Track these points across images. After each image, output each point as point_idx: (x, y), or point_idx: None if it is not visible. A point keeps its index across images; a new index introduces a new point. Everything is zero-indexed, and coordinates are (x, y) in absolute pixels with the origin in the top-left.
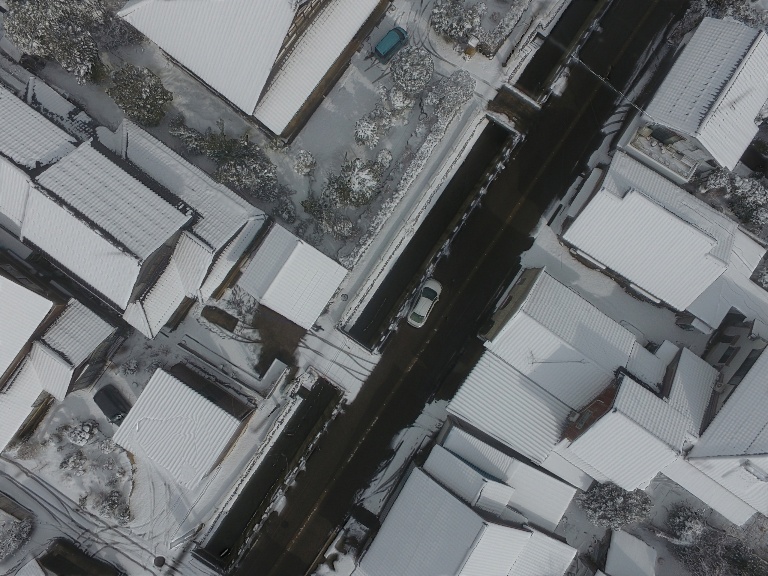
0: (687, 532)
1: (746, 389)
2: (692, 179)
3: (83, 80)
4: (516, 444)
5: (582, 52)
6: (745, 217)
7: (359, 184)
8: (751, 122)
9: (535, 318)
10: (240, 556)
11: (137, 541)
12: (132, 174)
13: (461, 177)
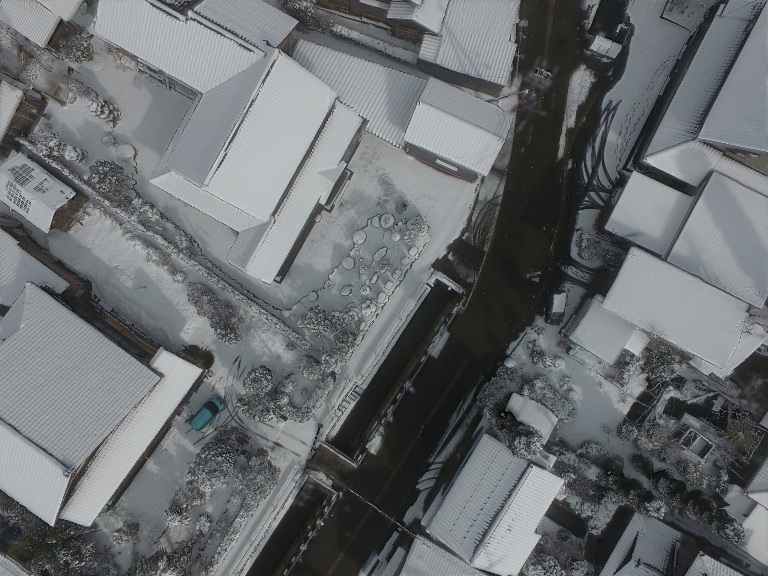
0: None
1: None
2: None
3: None
4: None
5: (396, 411)
6: None
7: None
8: (531, 534)
9: None
10: None
11: None
12: None
13: (287, 521)
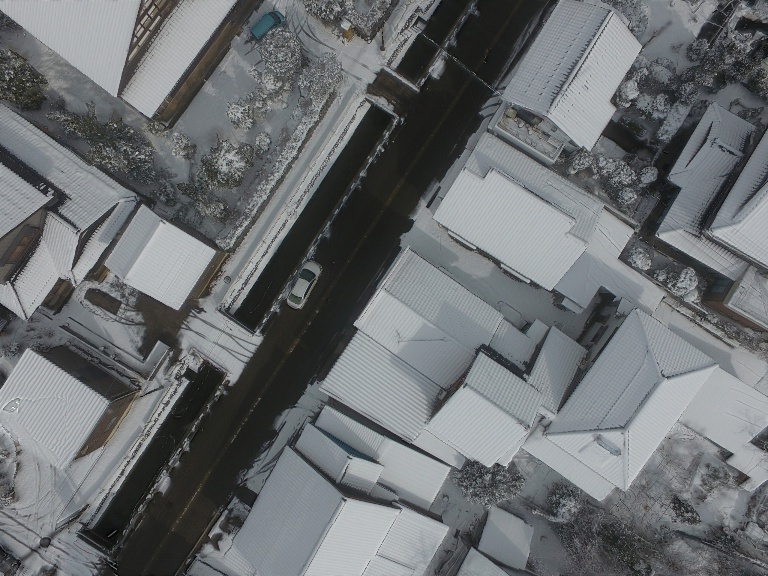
0: (562, 509)
1: (601, 365)
2: (562, 160)
3: None
4: (387, 423)
5: (460, 36)
6: (614, 197)
7: (227, 165)
8: (607, 102)
9: (397, 297)
10: (125, 536)
11: (23, 522)
12: None
13: (345, 160)
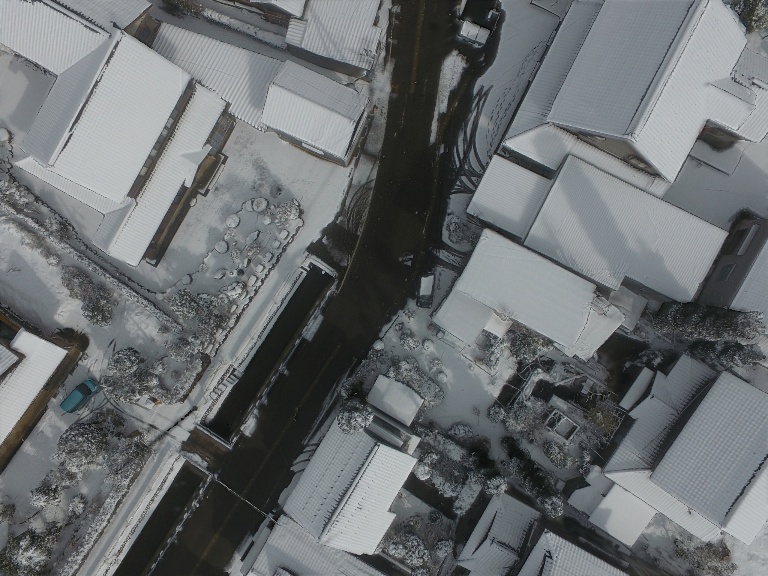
0: None
1: None
2: None
3: None
4: None
5: (270, 394)
6: None
7: (26, 561)
8: (384, 513)
9: None
10: None
11: None
12: None
13: (167, 504)
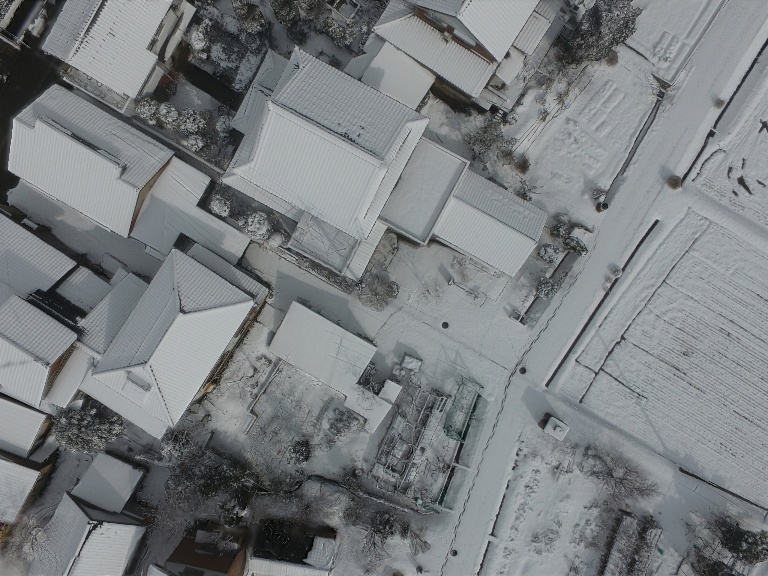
0: (162, 453)
1: (141, 305)
2: None
3: None
4: None
5: None
6: None
7: None
8: (143, 49)
9: None
10: None
11: None
12: None
13: None
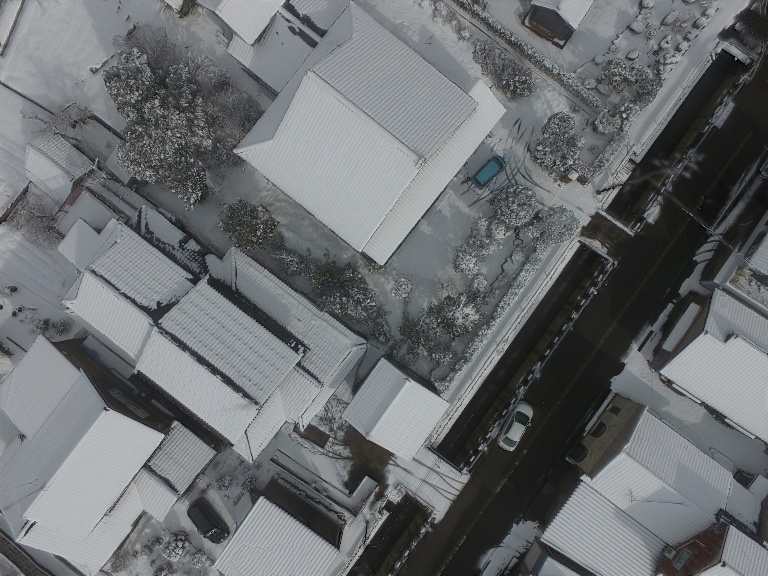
0: None
1: None
2: None
3: (191, 206)
4: None
5: (675, 181)
6: None
7: (462, 319)
8: None
9: (637, 460)
10: None
11: None
12: (246, 312)
13: (550, 297)
